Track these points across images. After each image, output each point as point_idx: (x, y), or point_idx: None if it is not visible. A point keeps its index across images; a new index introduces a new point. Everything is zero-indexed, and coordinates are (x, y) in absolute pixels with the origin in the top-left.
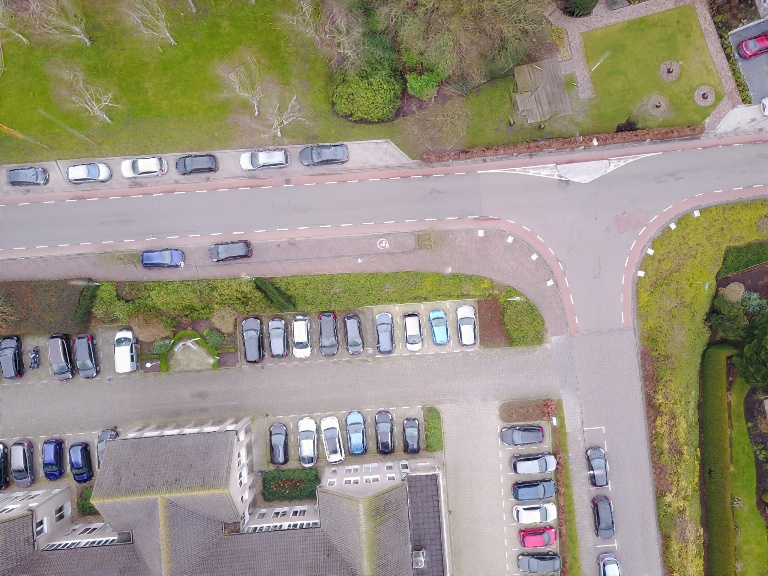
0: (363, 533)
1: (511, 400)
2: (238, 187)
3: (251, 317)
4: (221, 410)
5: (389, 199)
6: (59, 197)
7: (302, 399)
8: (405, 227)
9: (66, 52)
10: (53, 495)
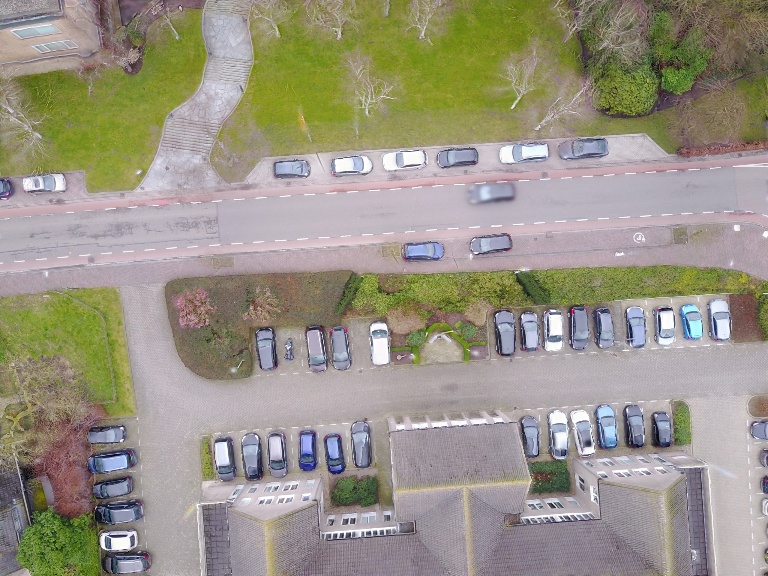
0: (665, 525)
1: (761, 394)
2: (496, 180)
3: (504, 310)
4: (470, 402)
5: (645, 193)
6: (320, 189)
7: (550, 392)
8: (661, 221)
9: (317, 45)
10: (317, 485)
